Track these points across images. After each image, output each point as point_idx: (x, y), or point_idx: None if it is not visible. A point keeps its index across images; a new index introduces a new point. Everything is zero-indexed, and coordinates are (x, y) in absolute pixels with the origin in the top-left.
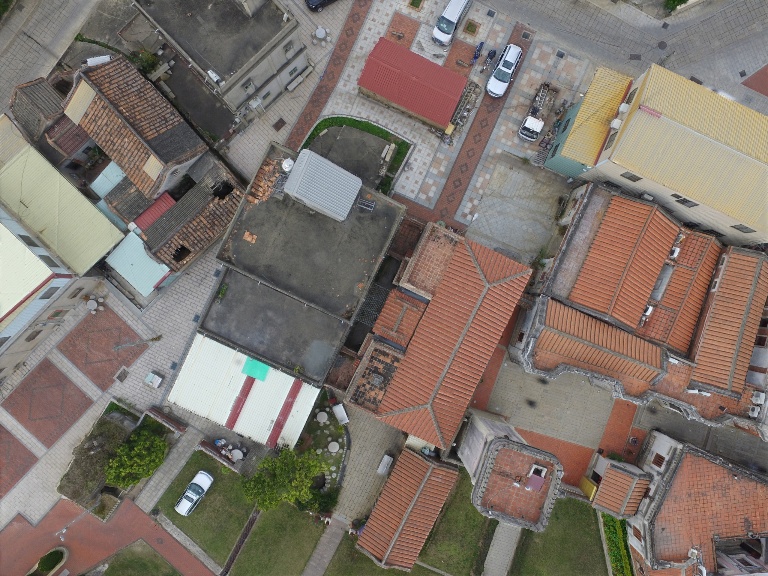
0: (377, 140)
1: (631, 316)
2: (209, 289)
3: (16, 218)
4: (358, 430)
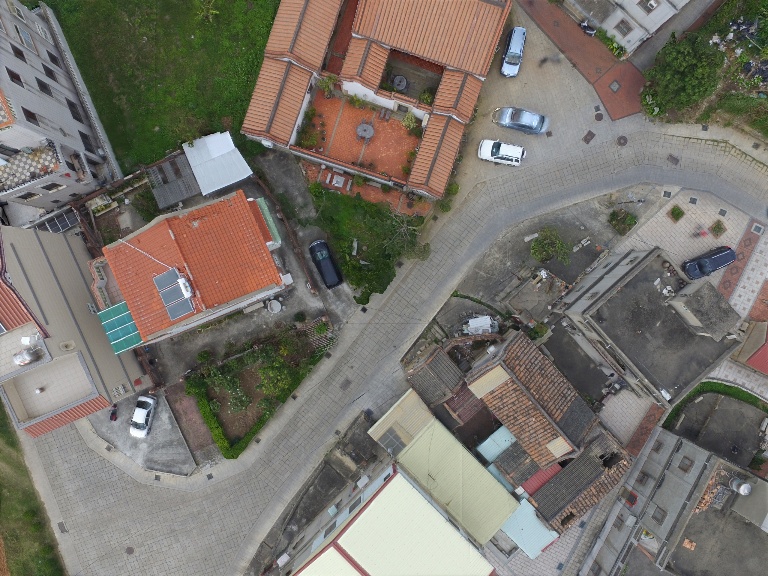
0: (755, 411)
1: None
2: (574, 539)
3: (427, 492)
4: None
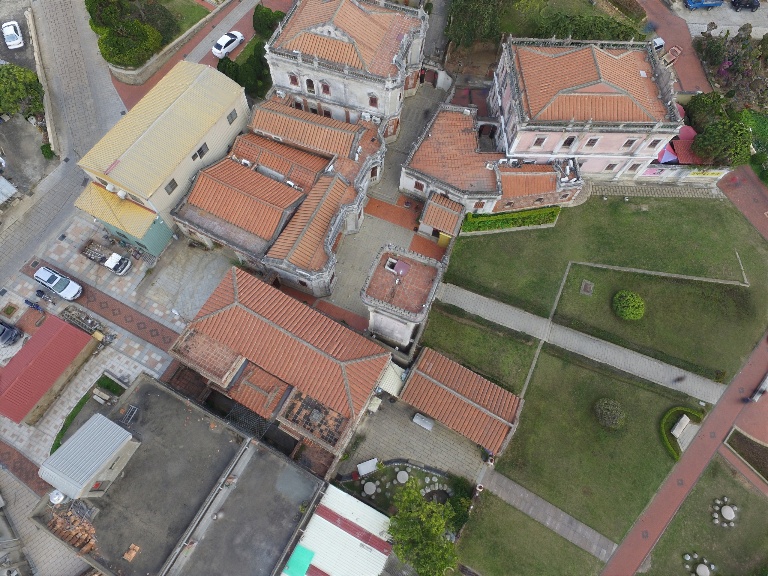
0: (86, 408)
1: (292, 196)
2: None
3: None
4: (388, 449)
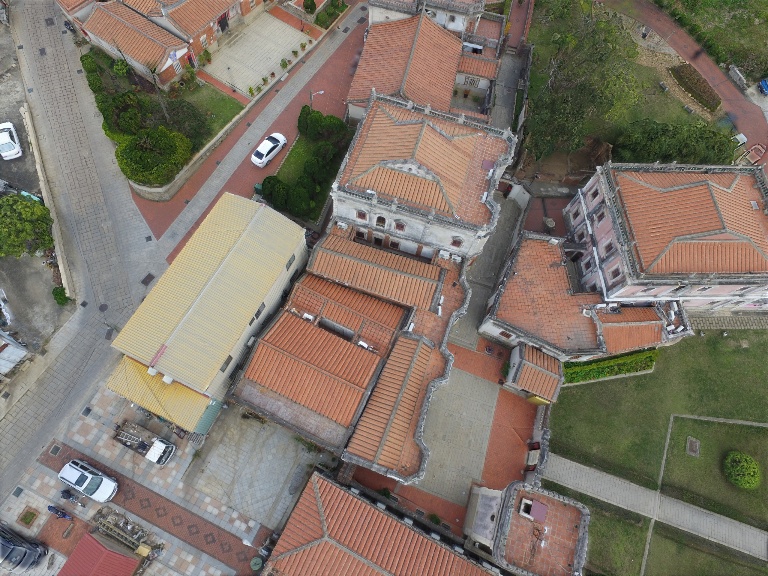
0: None
1: (368, 363)
2: None
3: None
4: None
